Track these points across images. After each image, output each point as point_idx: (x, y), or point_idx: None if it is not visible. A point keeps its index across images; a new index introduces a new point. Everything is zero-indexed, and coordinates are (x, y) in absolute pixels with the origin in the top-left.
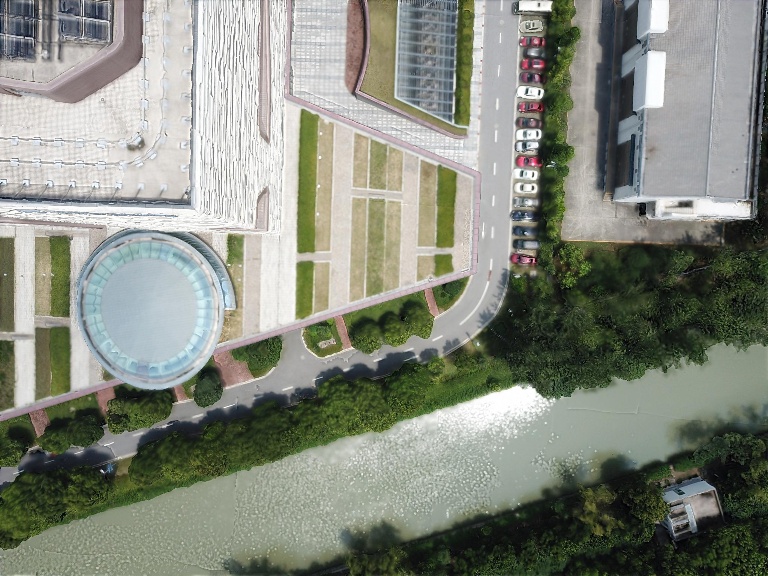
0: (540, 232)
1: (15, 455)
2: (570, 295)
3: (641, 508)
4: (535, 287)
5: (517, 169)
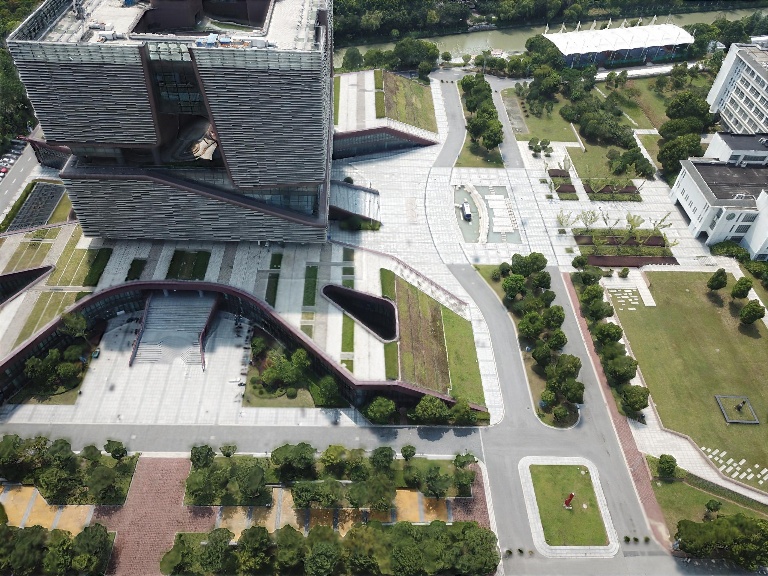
0: (8, 145)
1: None
2: (2, 114)
3: (5, 54)
4: (21, 122)
5: (8, 168)
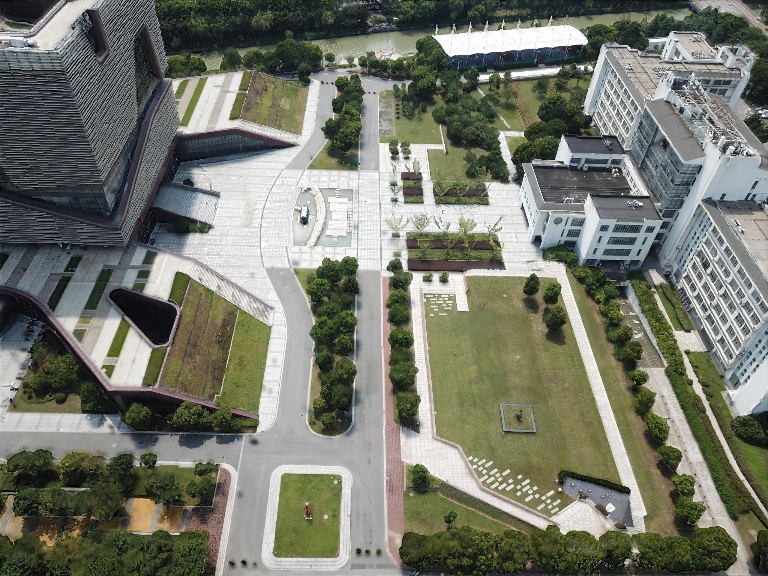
0: None
1: (175, 78)
2: None
3: None
4: None
5: None
